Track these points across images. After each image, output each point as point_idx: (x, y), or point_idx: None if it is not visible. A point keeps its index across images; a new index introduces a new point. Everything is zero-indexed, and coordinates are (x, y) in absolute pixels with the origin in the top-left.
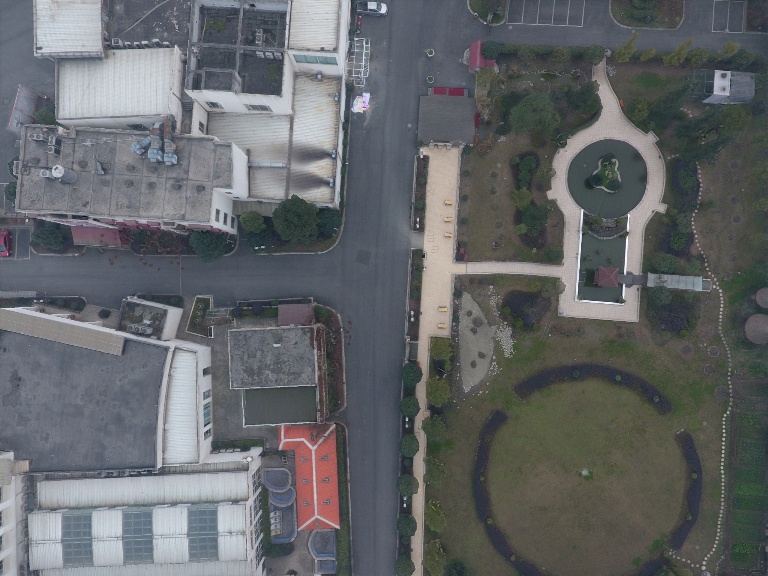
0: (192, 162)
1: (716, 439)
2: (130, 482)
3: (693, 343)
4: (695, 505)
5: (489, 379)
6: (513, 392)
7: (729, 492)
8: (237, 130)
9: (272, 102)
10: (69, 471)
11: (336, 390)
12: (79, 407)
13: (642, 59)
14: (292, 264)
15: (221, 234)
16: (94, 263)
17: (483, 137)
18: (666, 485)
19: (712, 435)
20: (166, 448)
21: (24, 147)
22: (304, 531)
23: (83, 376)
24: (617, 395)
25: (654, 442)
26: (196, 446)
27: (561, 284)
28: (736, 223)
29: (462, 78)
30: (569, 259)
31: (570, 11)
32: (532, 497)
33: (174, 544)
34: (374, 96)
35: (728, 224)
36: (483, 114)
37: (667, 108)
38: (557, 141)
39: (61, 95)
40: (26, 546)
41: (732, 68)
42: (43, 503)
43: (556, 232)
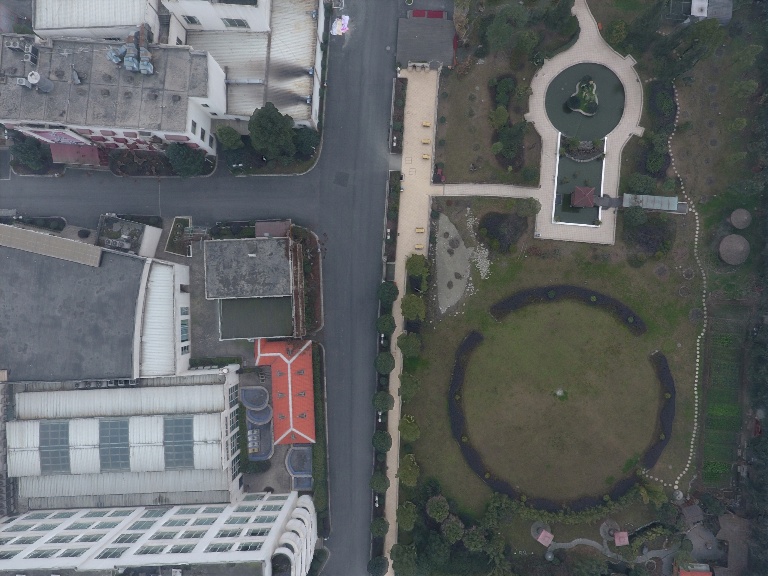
0: (168, 72)
1: (690, 360)
2: (108, 394)
3: (668, 265)
4: (668, 424)
5: (465, 300)
6: (489, 313)
7: (702, 412)
8: (215, 48)
9: (248, 14)
10: (47, 380)
11: (313, 310)
12: (57, 318)
13: None
14: (271, 186)
15: (198, 150)
16: (74, 184)
17: (461, 60)
18: (640, 406)
19: (686, 356)
20: (143, 360)
21: (1, 56)
22: (281, 449)
23: (61, 288)
24: (592, 317)
25: (629, 363)
26: (173, 359)
27: (537, 203)
28: (713, 147)
29: (441, 1)
30: (546, 182)
31: None
32: (507, 417)
33: (150, 452)
34: (353, 19)
35: (705, 148)
36: (461, 37)
37: (644, 27)
38: (534, 60)
39: (38, 6)
40: (5, 457)
41: None
42: (22, 414)
43: (533, 155)
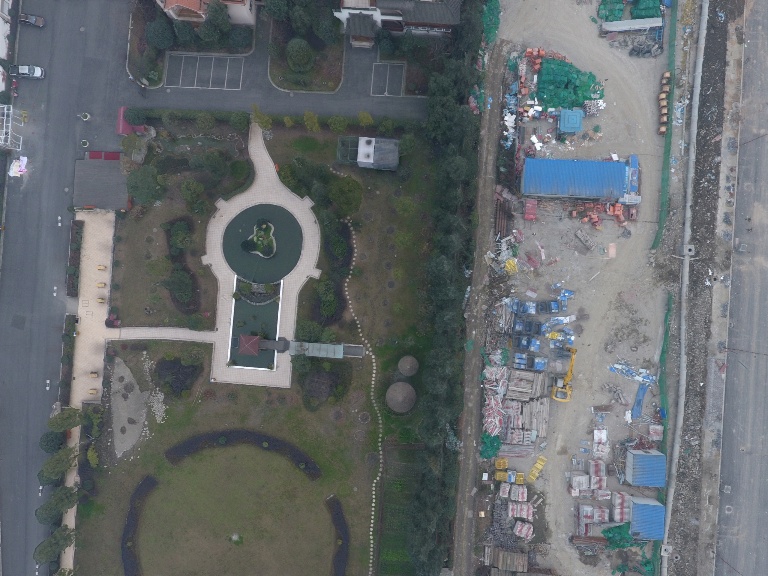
0: None
1: (366, 505)
2: None
3: (345, 409)
4: (340, 571)
5: (141, 444)
6: (164, 457)
7: None
8: None
9: None
10: None
11: None
12: None
13: (286, 126)
14: None
15: None
16: None
17: None
18: (315, 550)
19: (362, 501)
20: None
21: None
22: None
23: None
24: (268, 460)
25: (304, 507)
26: None
27: (199, 353)
28: (390, 289)
29: (119, 142)
30: (223, 324)
31: (228, 74)
32: (182, 562)
33: None
34: (31, 160)
35: (382, 290)
36: None
37: (303, 177)
38: (193, 210)
39: None
40: None
41: (378, 134)
42: None
43: (210, 297)
